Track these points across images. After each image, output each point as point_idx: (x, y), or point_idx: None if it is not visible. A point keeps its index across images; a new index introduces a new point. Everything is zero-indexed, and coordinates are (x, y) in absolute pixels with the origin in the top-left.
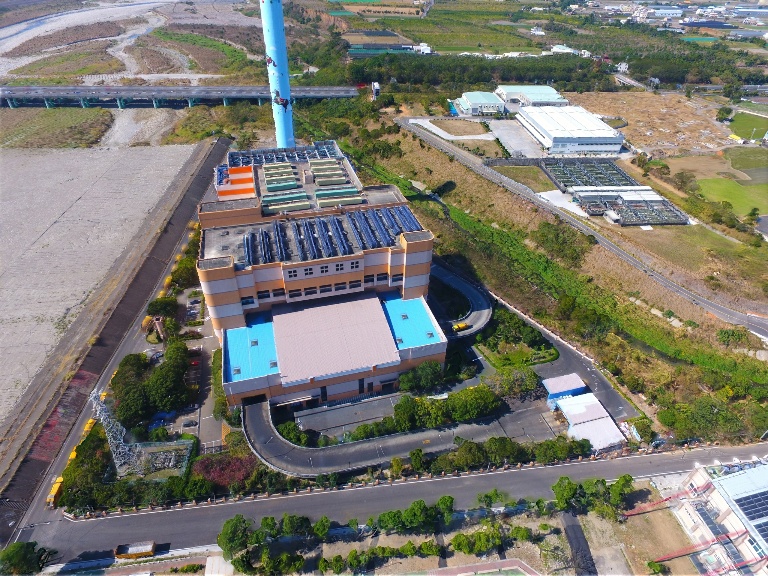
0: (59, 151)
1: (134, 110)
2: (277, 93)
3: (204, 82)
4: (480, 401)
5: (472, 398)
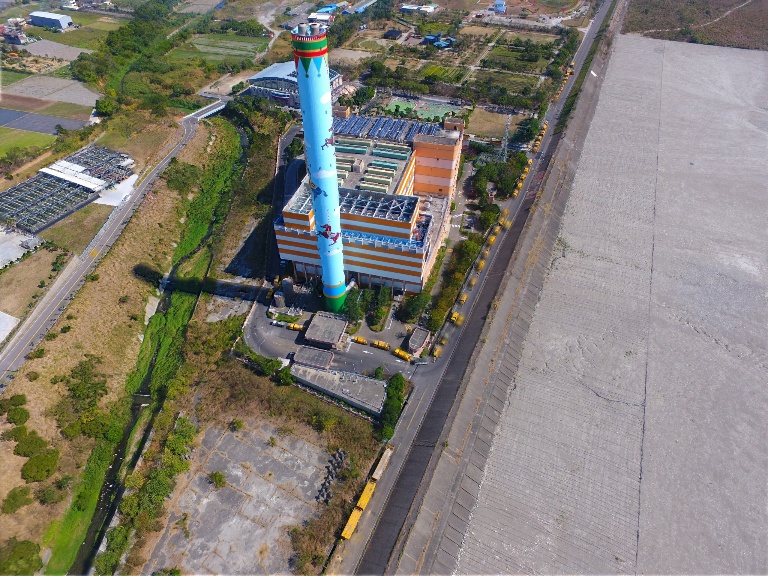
0: None
1: None
2: None
3: None
4: None
5: None
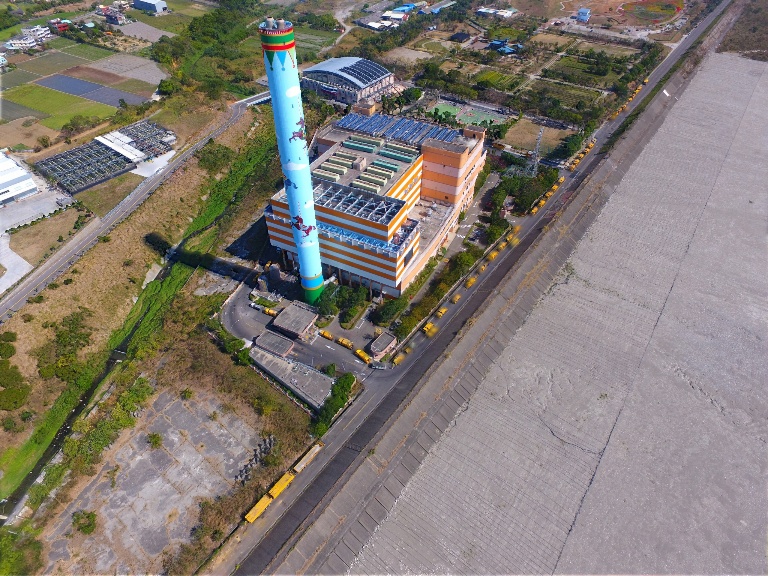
0: None
1: None
2: None
3: None
4: None
5: None
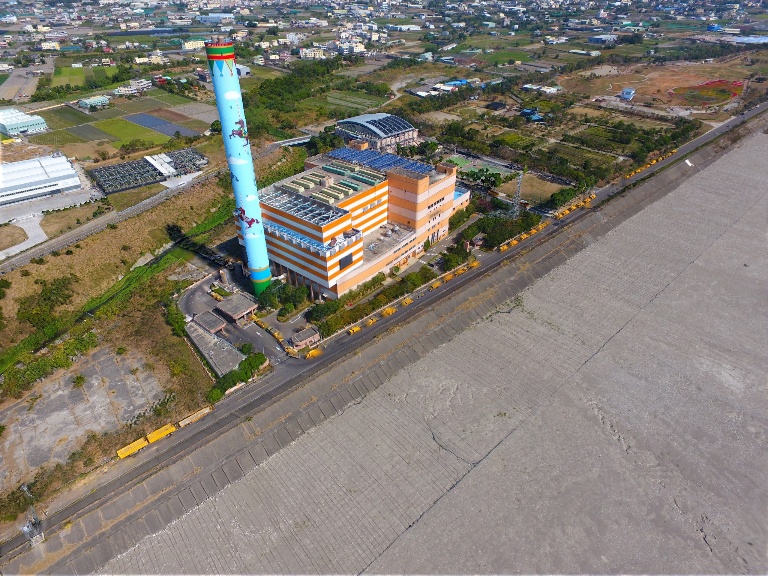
0: None
1: None
2: None
3: None
4: None
5: None
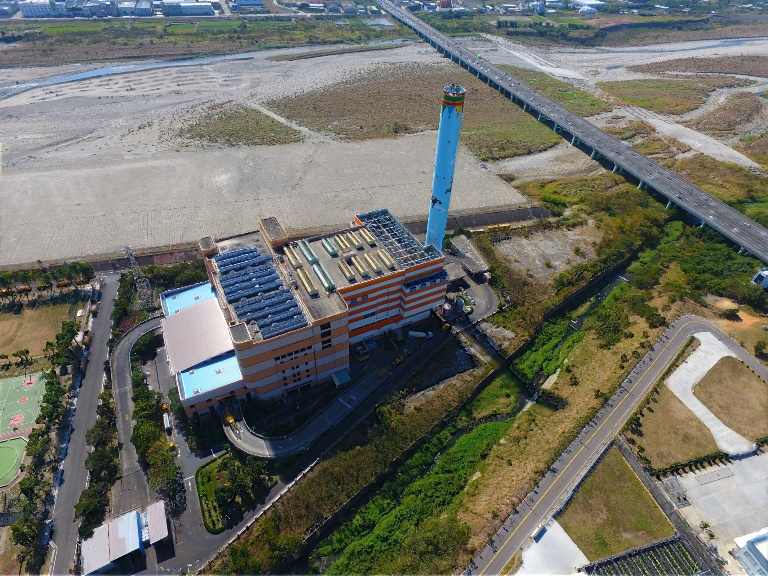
0: (464, 152)
1: (575, 151)
2: (432, 189)
3: (693, 158)
4: (139, 441)
5: (139, 433)
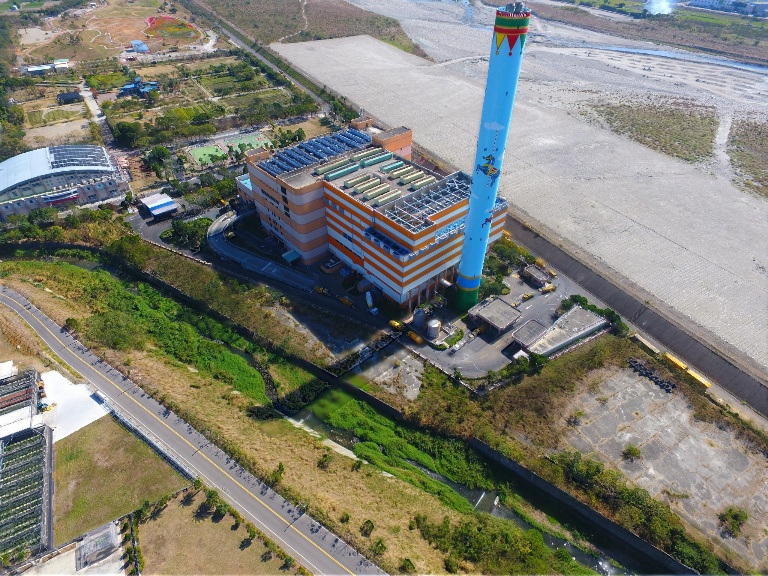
0: None
1: None
2: None
3: None
4: None
5: (221, 181)
